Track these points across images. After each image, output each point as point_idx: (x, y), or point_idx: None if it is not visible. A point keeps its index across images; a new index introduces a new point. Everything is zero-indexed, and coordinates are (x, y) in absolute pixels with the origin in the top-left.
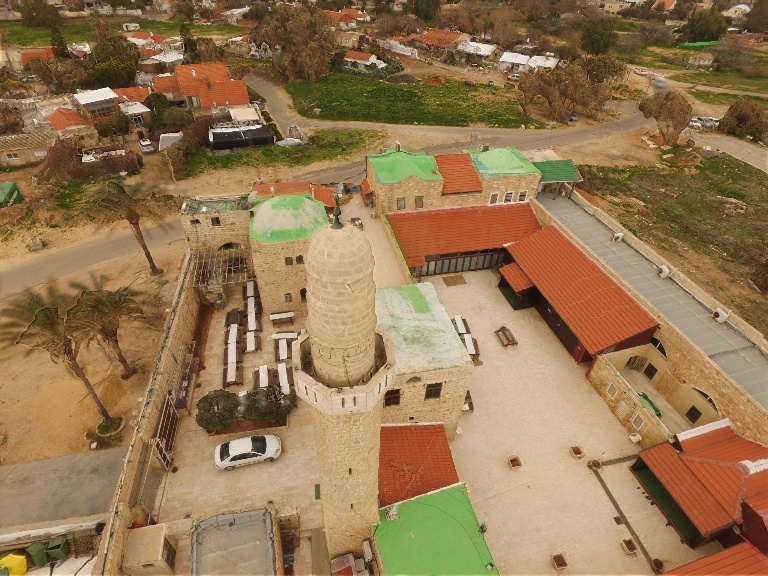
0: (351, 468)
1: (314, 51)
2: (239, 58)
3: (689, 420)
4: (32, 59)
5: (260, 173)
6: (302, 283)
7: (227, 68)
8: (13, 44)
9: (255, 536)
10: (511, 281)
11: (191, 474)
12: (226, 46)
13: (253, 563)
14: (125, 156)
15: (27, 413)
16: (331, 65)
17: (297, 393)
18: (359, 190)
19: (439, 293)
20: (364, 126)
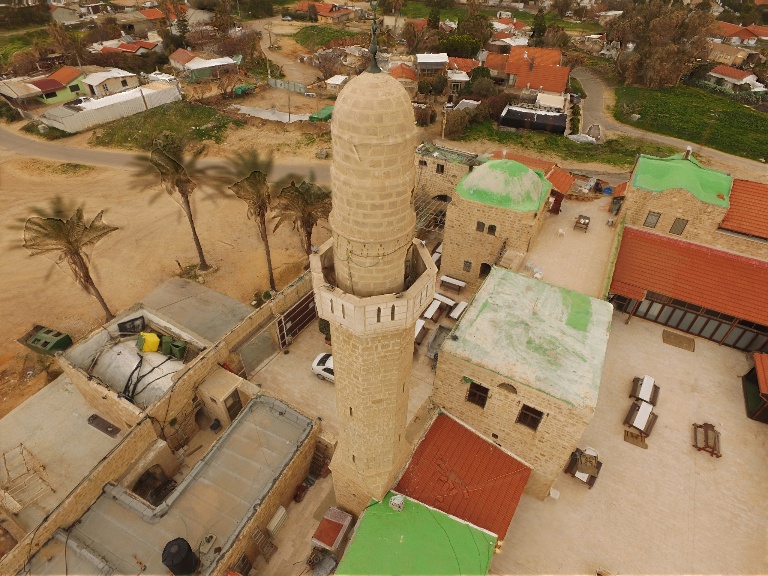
0: (352, 408)
1: (670, 55)
2: (586, 54)
3: None
4: (407, 24)
5: (528, 155)
6: (486, 257)
7: (562, 56)
8: (404, 13)
9: (290, 436)
10: (763, 376)
11: (294, 363)
12: (581, 42)
13: (273, 455)
14: (423, 109)
15: (239, 261)
16: (688, 77)
17: None
18: (613, 193)
19: (646, 343)
20: (684, 145)
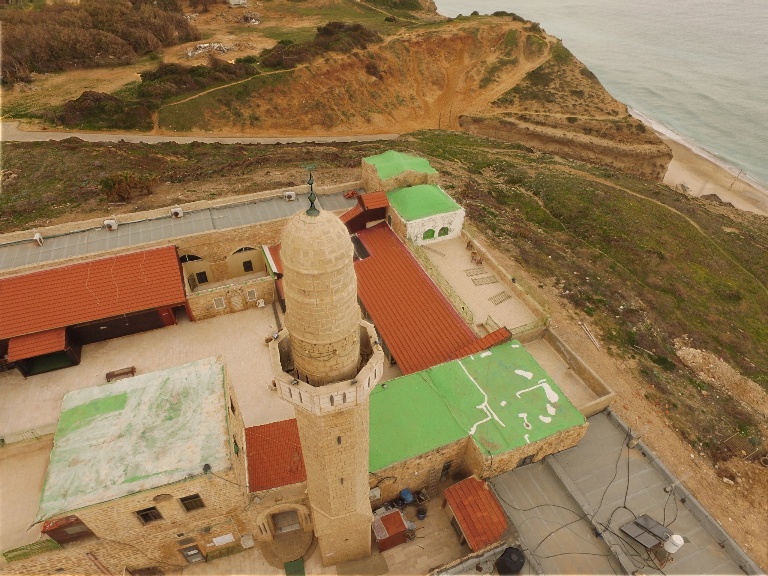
0: None
1: None
2: None
3: (249, 272)
4: None
5: None
6: None
7: None
8: None
9: None
10: (42, 351)
11: None
12: None
13: None
14: None
15: None
16: None
17: (362, 402)
18: None
19: None
20: None
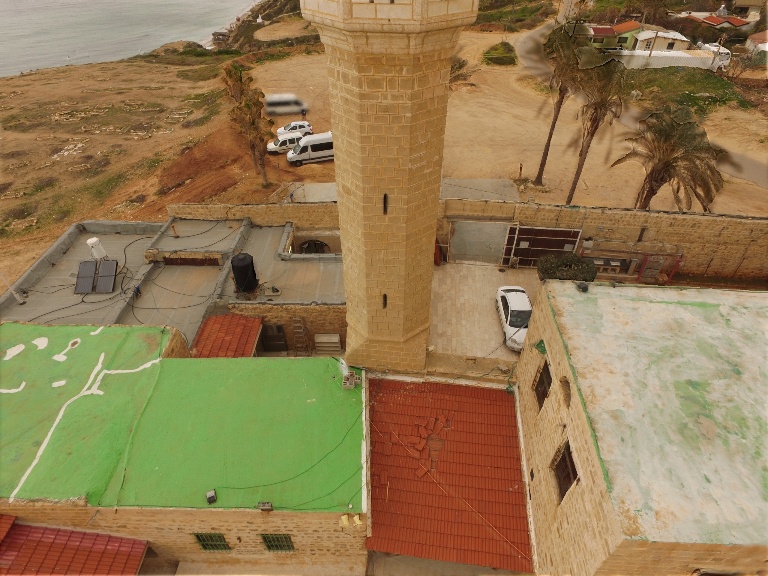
0: None
1: None
2: None
3: None
4: None
5: None
6: None
7: None
8: None
9: None
10: None
11: (495, 280)
12: None
13: None
14: None
15: (574, 198)
16: None
17: None
18: None
19: None
20: None
